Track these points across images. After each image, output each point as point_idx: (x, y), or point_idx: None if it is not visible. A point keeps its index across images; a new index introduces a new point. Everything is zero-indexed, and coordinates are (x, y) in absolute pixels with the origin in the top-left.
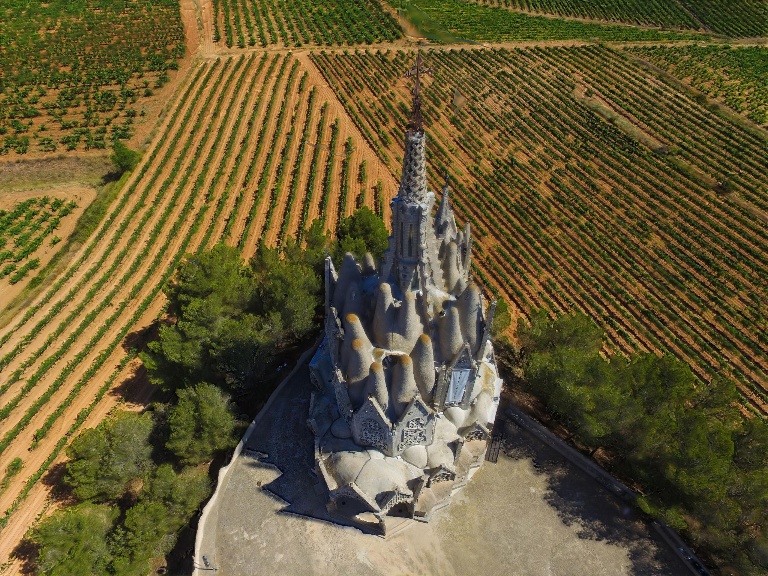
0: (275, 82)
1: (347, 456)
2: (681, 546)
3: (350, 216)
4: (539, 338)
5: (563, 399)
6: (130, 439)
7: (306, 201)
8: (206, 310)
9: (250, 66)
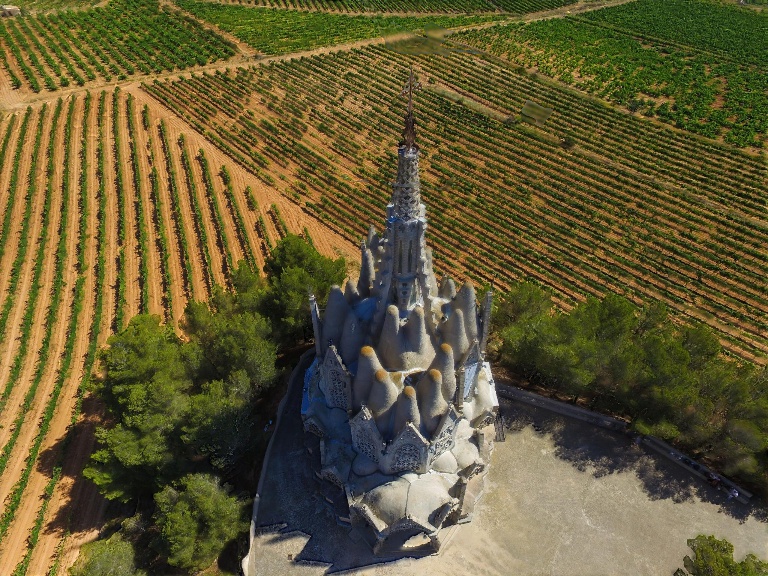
0: (112, 122)
1: (386, 490)
2: (671, 451)
3: (276, 247)
4: (498, 314)
5: (550, 362)
6: (117, 574)
7: (201, 243)
8: (158, 394)
9: (73, 109)
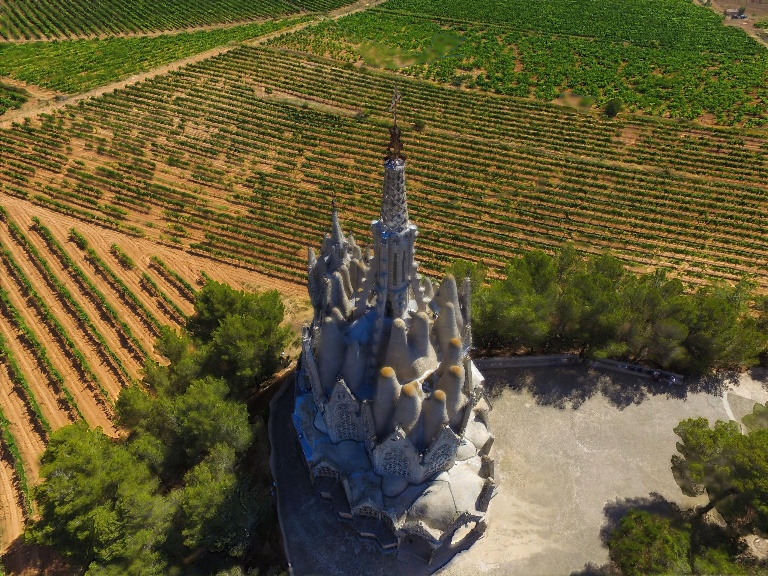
0: None
1: (430, 499)
2: (618, 364)
3: (198, 300)
4: None
5: (512, 324)
6: None
7: (81, 324)
8: (134, 508)
9: None
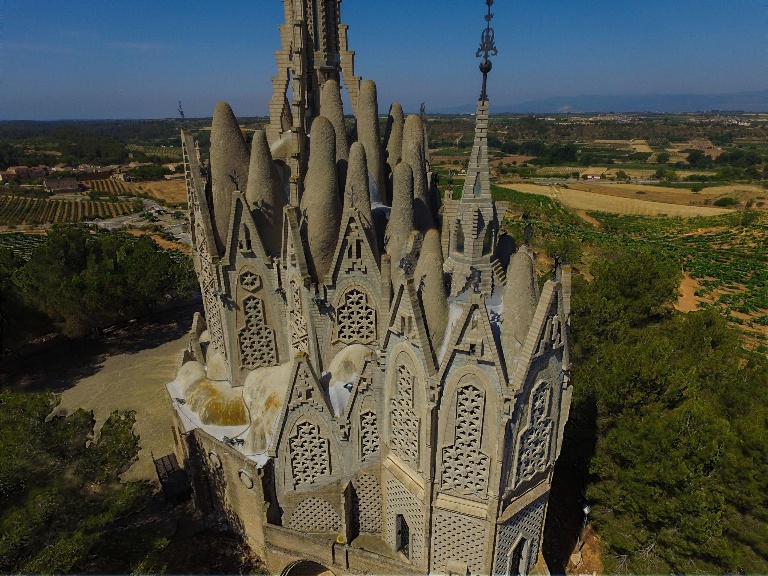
0: None
1: None
2: None
3: None
4: None
5: None
6: None
7: None
8: None
9: None
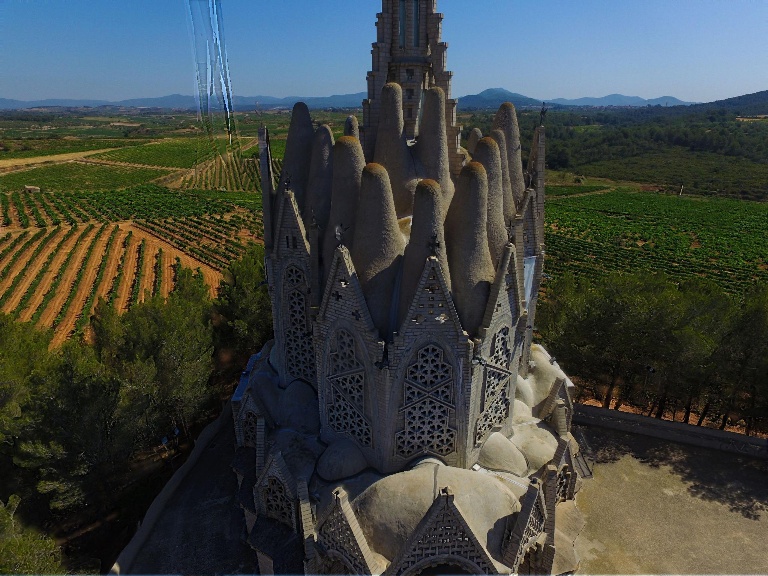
0: (91, 243)
1: (388, 477)
2: None
3: None
4: (535, 320)
5: (639, 322)
6: None
7: None
8: None
9: (55, 236)
